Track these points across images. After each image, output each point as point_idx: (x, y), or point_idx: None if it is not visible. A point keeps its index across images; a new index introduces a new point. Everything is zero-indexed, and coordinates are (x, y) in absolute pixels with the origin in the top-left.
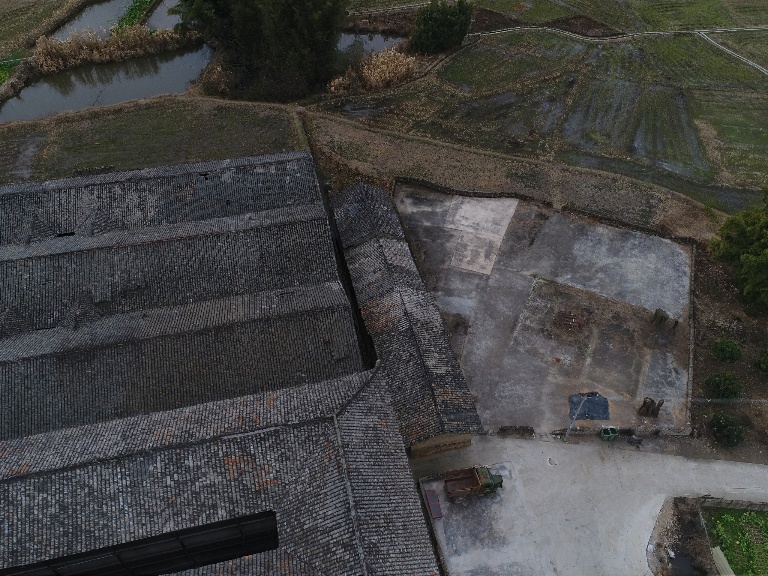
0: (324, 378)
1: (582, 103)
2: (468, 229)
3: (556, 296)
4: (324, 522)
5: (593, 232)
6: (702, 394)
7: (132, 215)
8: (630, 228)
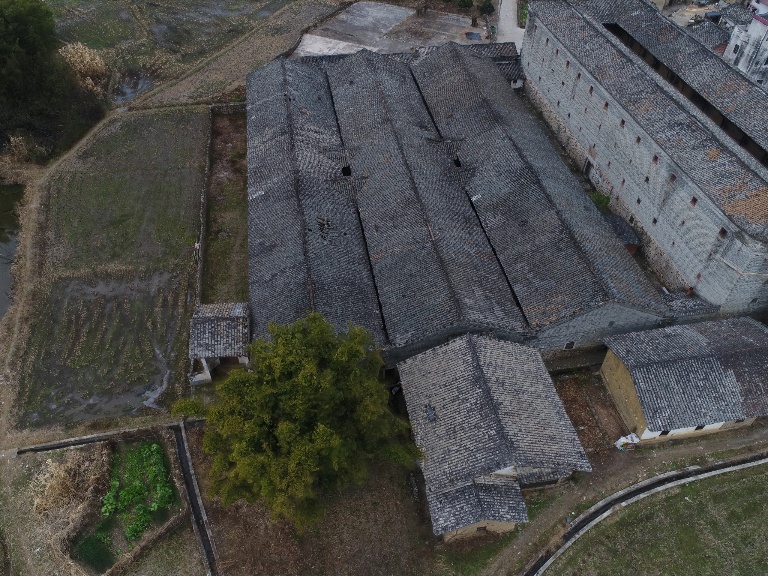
0: (490, 65)
1: (186, 5)
2: (333, 51)
3: (398, 34)
4: (607, 7)
5: (344, 19)
6: (464, 13)
7: (327, 139)
8: (343, 9)
